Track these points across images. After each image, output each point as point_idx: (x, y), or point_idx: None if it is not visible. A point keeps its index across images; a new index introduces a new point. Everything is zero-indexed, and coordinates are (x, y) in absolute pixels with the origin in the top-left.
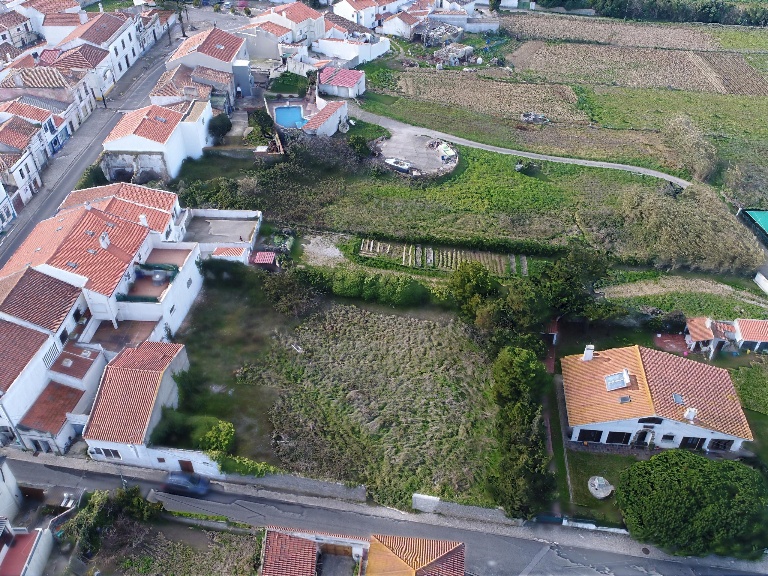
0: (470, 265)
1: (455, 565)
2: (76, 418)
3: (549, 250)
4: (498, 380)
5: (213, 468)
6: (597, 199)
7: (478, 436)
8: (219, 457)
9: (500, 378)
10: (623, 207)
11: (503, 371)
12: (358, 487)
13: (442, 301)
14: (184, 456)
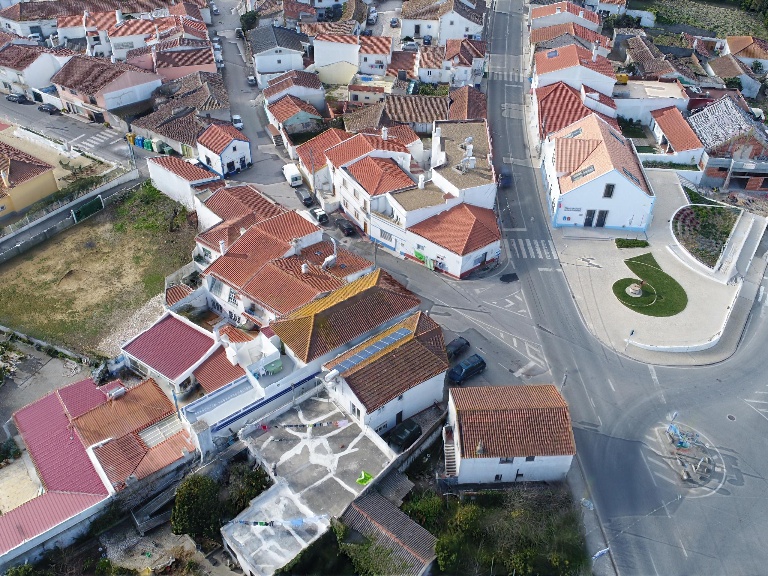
0: None
1: (764, 43)
2: (590, 1)
3: None
4: None
5: (651, 21)
6: None
7: (759, 36)
8: (658, 12)
9: None
10: None
11: None
12: (714, 32)
13: (732, 1)
14: (640, 14)
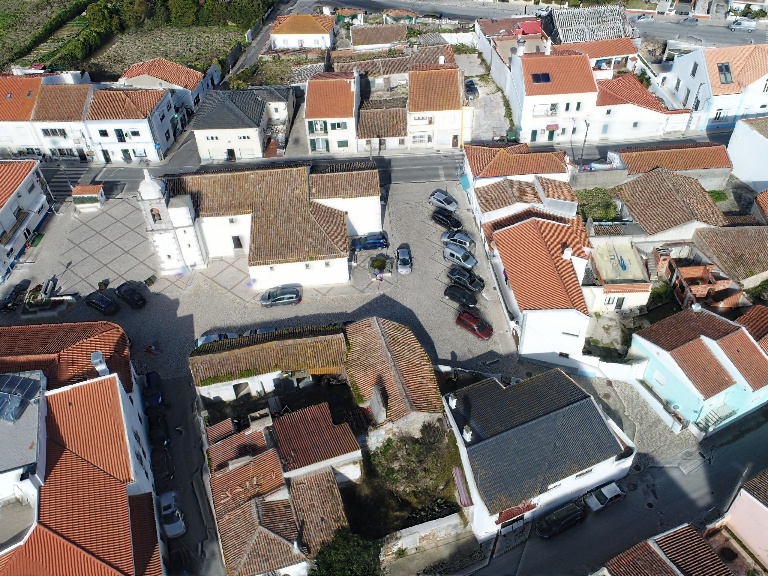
0: (93, 6)
1: None
2: None
3: (70, 11)
4: (189, 6)
5: None
6: (14, 7)
7: None
8: None
9: (188, 4)
10: (30, 1)
11: (185, 1)
12: None
13: (105, 34)
14: None
